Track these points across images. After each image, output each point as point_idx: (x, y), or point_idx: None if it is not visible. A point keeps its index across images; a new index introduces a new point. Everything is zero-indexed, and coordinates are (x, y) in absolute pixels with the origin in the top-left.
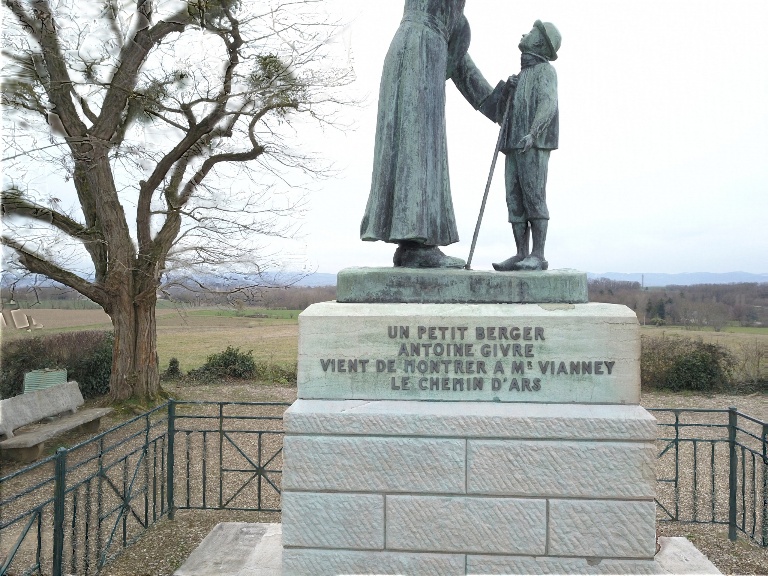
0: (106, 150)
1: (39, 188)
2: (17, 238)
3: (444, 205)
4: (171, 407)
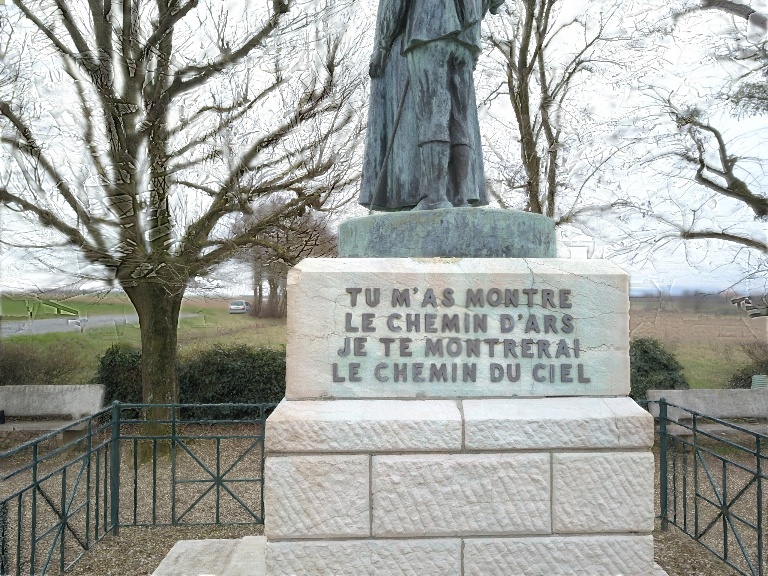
0: (650, 146)
1: (638, 194)
2: (634, 241)
3: (420, 157)
4: (661, 407)
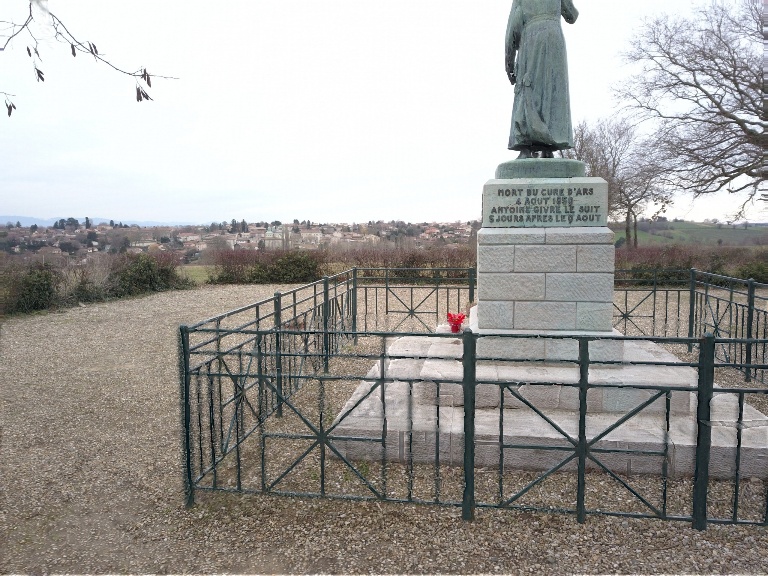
0: None
1: None
2: None
3: None
4: None
